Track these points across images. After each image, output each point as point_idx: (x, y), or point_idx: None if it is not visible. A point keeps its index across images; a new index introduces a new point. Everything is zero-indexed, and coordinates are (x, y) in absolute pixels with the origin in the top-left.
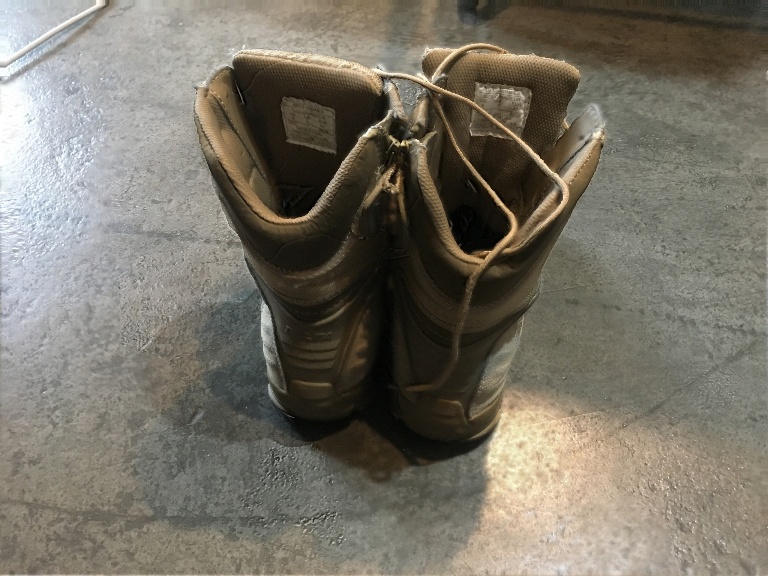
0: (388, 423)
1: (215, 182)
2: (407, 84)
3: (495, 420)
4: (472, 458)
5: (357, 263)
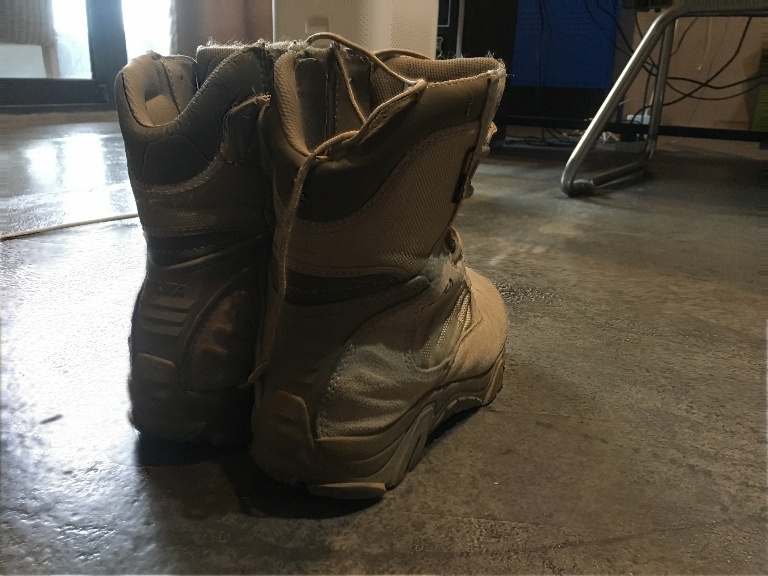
0: (239, 460)
1: None
2: None
3: (370, 484)
4: (323, 525)
5: (226, 201)
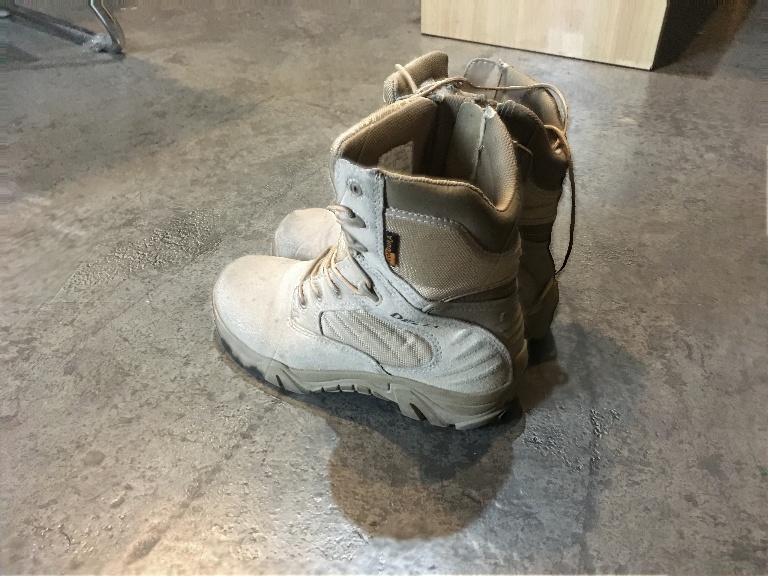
0: None
1: (449, 224)
2: (98, 258)
3: None
4: (555, 327)
5: None
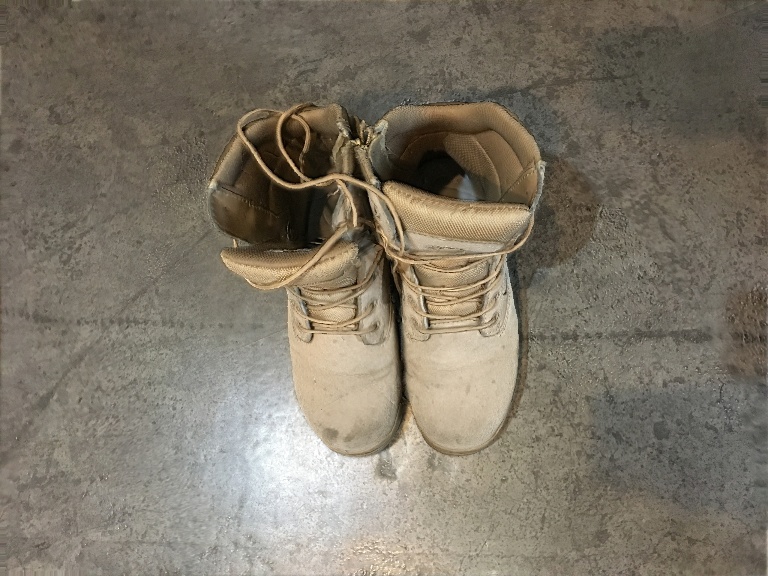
0: None
1: None
2: None
3: None
4: None
5: None
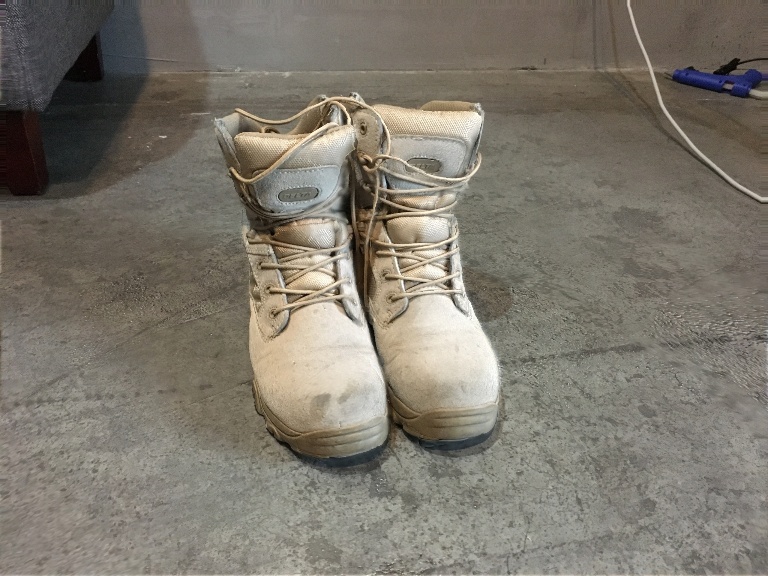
0: None
1: None
2: None
3: None
4: None
5: None
